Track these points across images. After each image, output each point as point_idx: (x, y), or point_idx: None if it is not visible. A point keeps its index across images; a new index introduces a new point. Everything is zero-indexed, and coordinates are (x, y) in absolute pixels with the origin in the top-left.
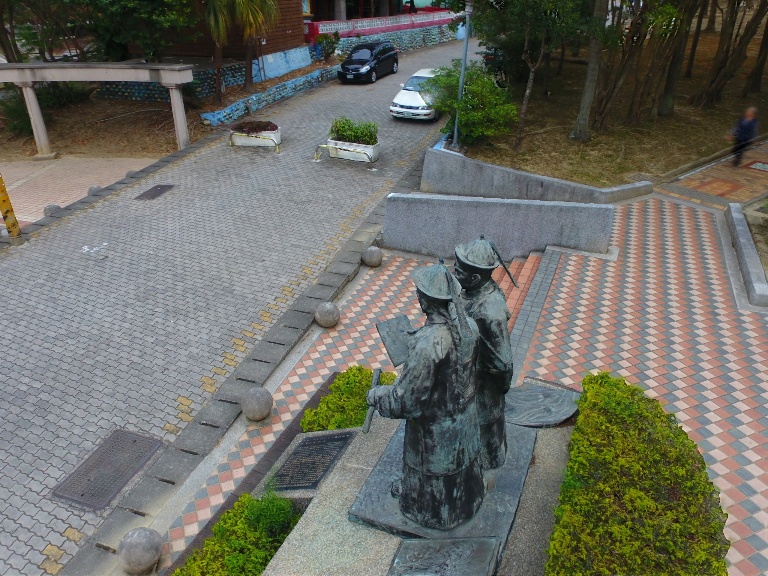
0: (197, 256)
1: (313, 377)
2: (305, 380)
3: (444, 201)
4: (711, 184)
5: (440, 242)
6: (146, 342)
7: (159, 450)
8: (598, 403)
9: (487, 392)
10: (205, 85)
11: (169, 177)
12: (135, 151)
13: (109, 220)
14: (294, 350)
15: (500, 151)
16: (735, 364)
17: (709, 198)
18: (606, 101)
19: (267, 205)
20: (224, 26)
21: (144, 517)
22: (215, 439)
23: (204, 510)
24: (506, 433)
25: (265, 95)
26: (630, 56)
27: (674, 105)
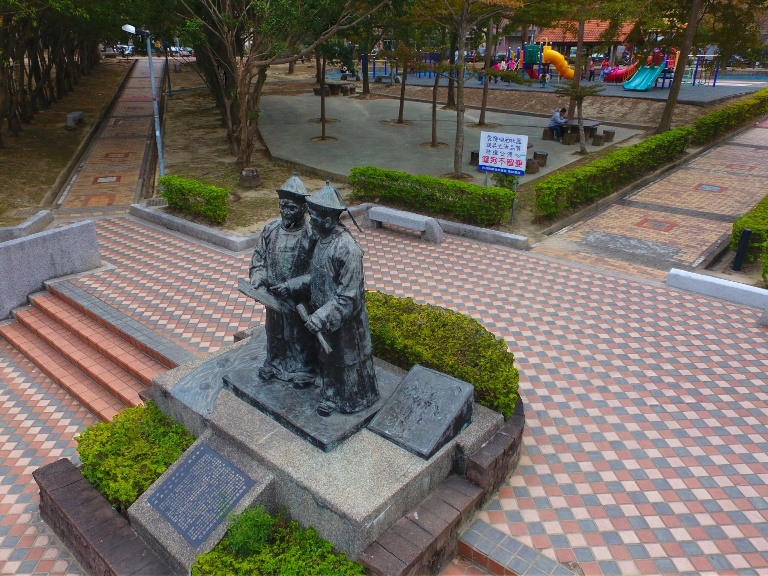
0: None
1: None
2: None
3: None
4: (91, 200)
5: None
6: None
7: None
8: None
9: None
10: None
11: None
12: None
13: None
14: None
15: None
16: None
17: (105, 209)
18: None
19: None
20: None
21: None
22: None
23: None
24: None
25: None
26: None
27: None
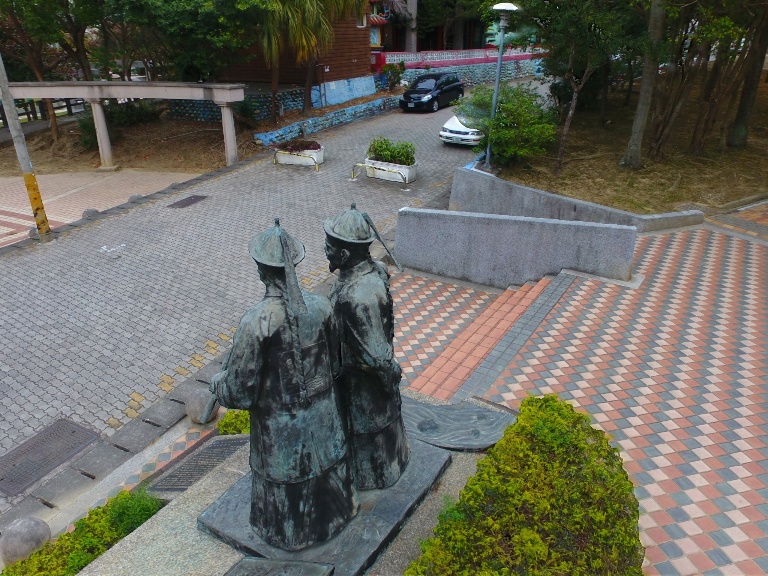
0: (203, 261)
1: None
2: None
3: (455, 217)
4: None
5: (451, 261)
6: (123, 337)
7: (93, 443)
8: (526, 427)
9: (365, 394)
10: (264, 108)
11: (206, 189)
12: (189, 167)
13: (136, 224)
14: None
15: (538, 174)
16: (747, 409)
17: None
18: (663, 127)
19: (289, 218)
20: (276, 48)
21: (51, 509)
22: (152, 438)
23: None
24: (414, 452)
25: (322, 119)
26: (689, 78)
27: (746, 135)
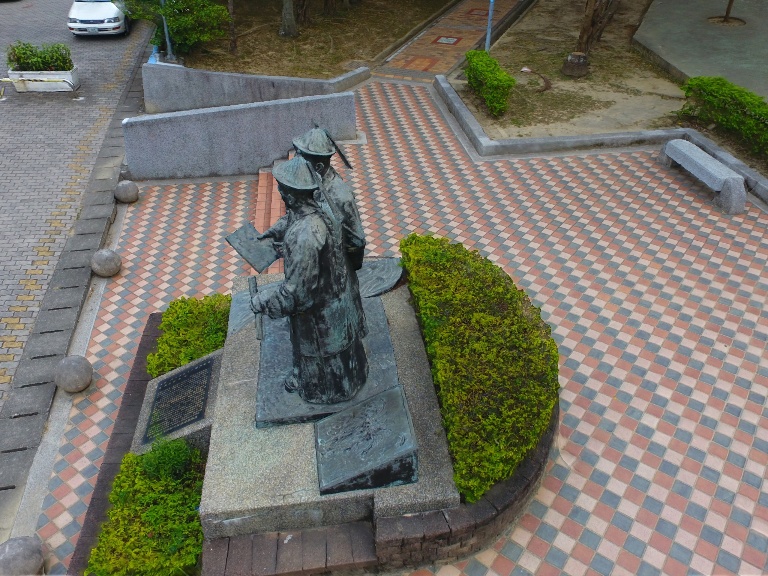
0: None
1: (121, 329)
2: (114, 335)
3: (188, 117)
4: (414, 62)
5: (195, 161)
6: None
7: None
8: (421, 259)
9: None
10: None
11: None
12: None
13: None
14: (84, 310)
15: (218, 57)
16: (488, 205)
17: (417, 74)
18: None
19: None
20: None
21: None
22: (40, 426)
23: (67, 497)
24: None
25: None
26: None
27: None
